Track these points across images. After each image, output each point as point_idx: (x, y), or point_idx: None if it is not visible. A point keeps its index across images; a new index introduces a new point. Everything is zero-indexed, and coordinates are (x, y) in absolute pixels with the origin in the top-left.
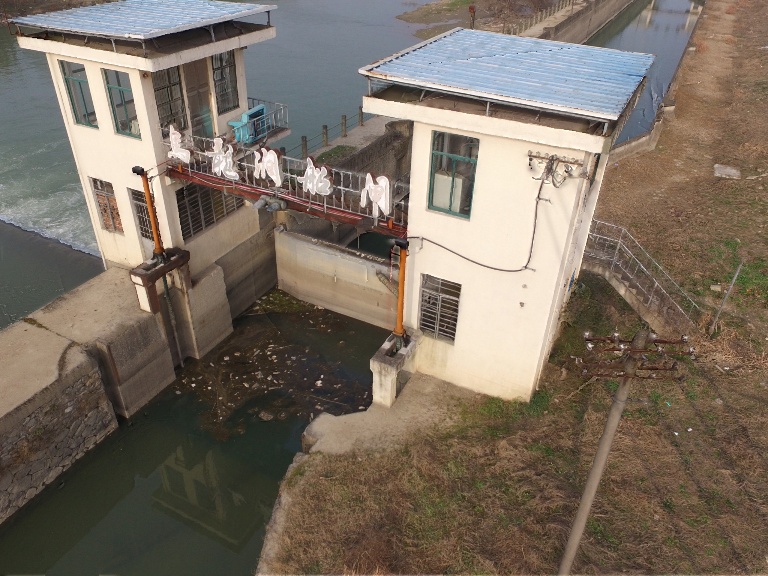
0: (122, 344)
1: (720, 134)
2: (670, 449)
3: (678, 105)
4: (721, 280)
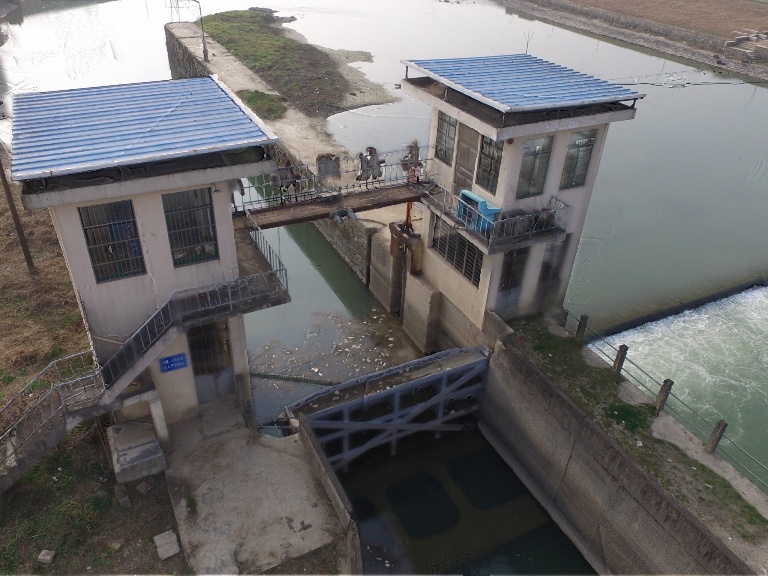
0: None
1: None
2: None
3: None
4: None
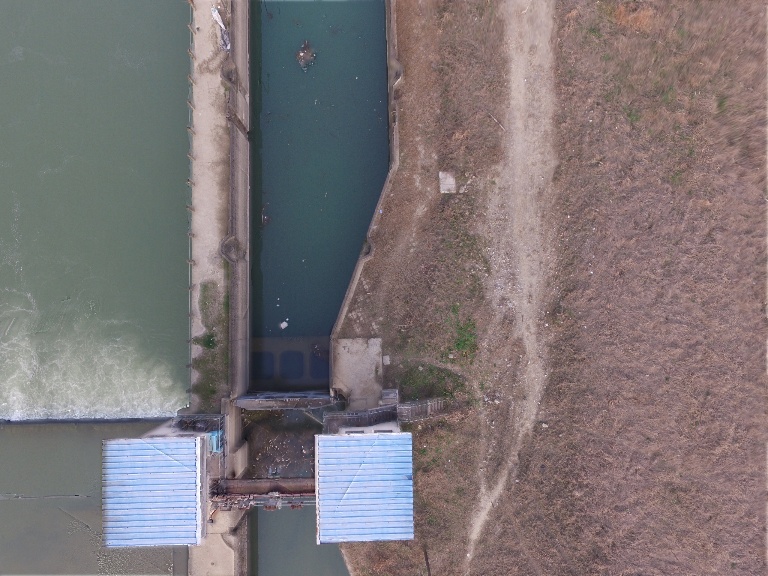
0: (236, 519)
1: (438, 104)
2: (444, 476)
3: (401, 39)
4: (452, 349)
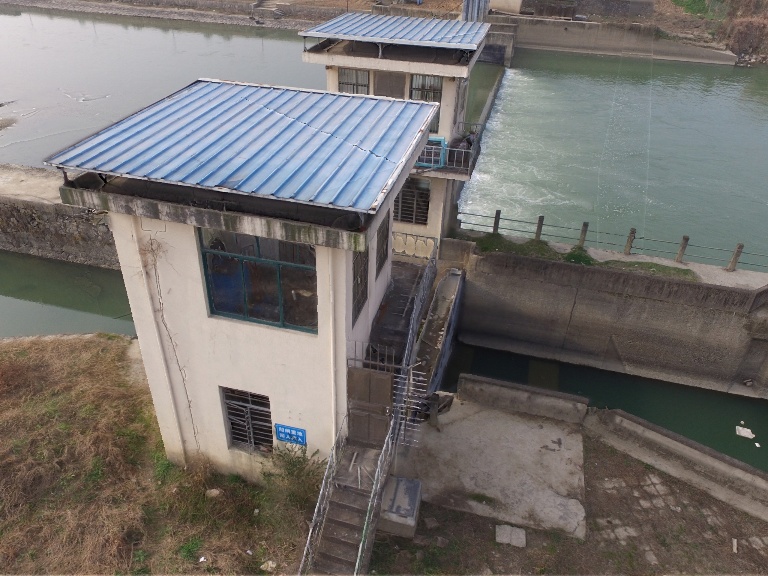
0: None
1: None
2: None
3: None
4: None
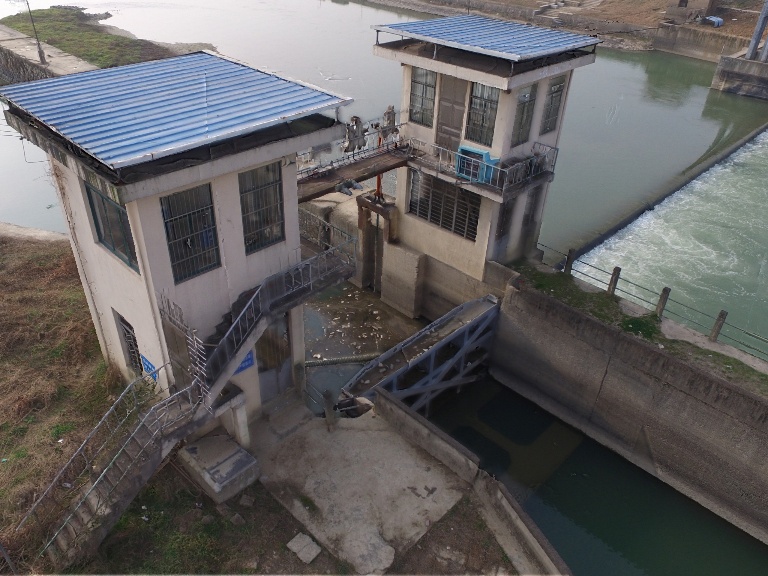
0: None
1: None
2: None
3: None
4: None
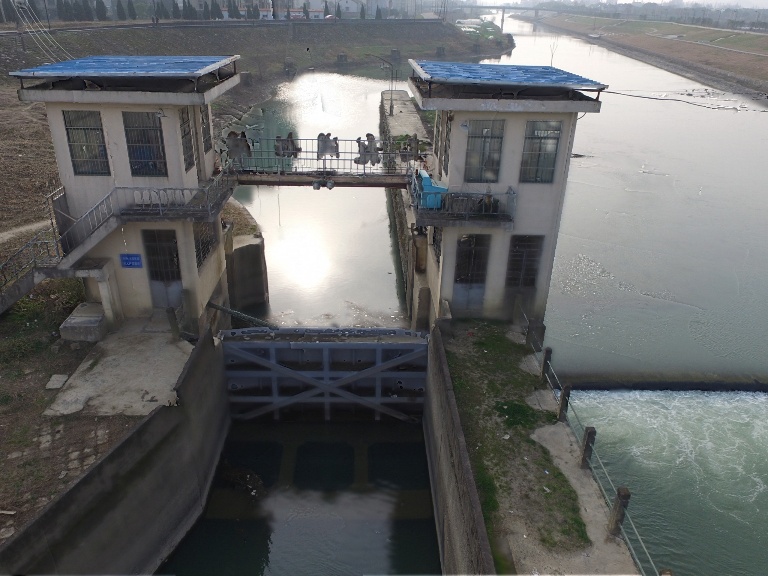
0: None
1: None
2: None
3: None
4: None
